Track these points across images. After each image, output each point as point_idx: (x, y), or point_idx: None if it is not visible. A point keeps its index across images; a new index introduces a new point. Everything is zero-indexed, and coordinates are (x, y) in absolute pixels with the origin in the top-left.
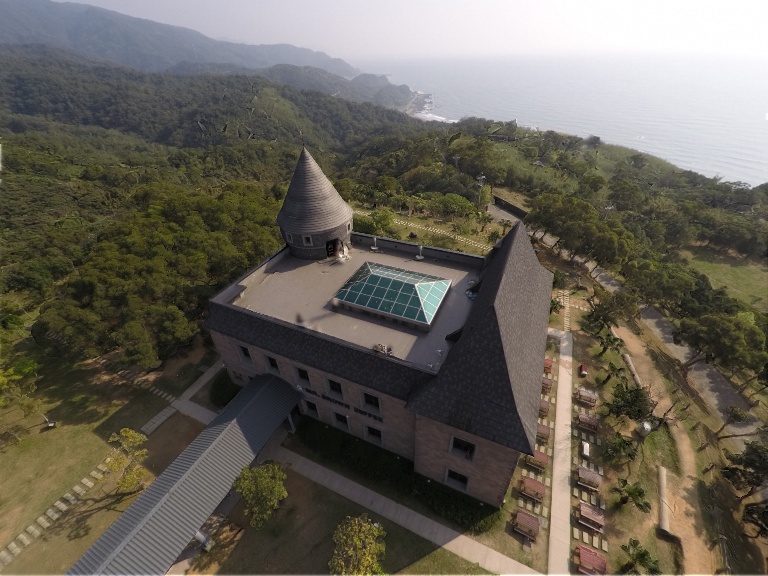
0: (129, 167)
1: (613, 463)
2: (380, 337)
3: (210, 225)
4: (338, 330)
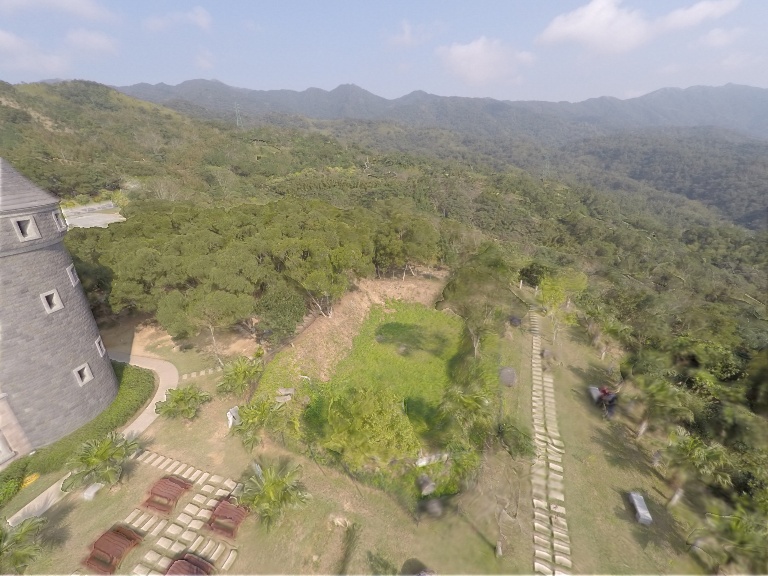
0: (628, 227)
1: None
2: None
3: None
4: None
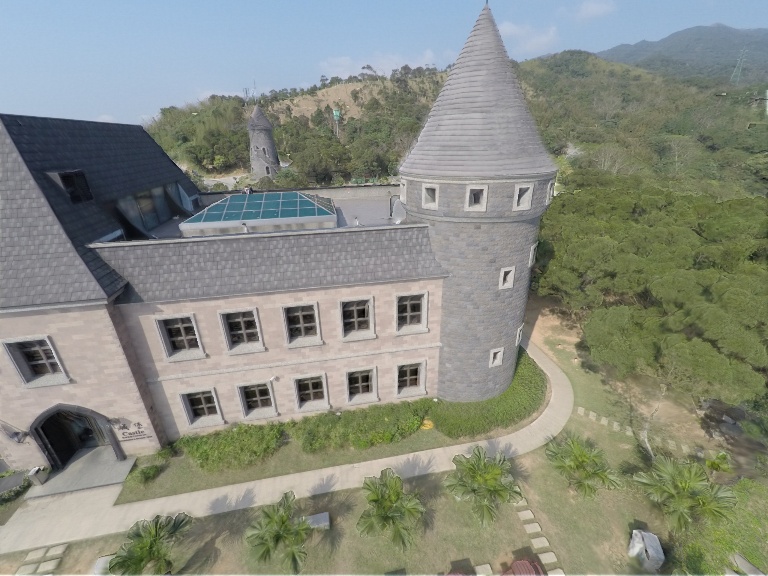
0: None
1: None
2: None
3: None
4: None
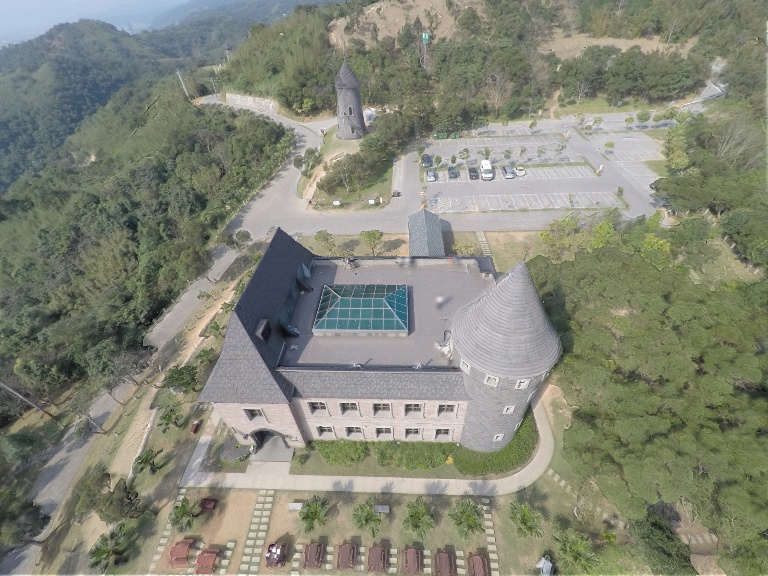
0: None
1: (213, 358)
2: (358, 278)
3: (755, 401)
4: (388, 275)
